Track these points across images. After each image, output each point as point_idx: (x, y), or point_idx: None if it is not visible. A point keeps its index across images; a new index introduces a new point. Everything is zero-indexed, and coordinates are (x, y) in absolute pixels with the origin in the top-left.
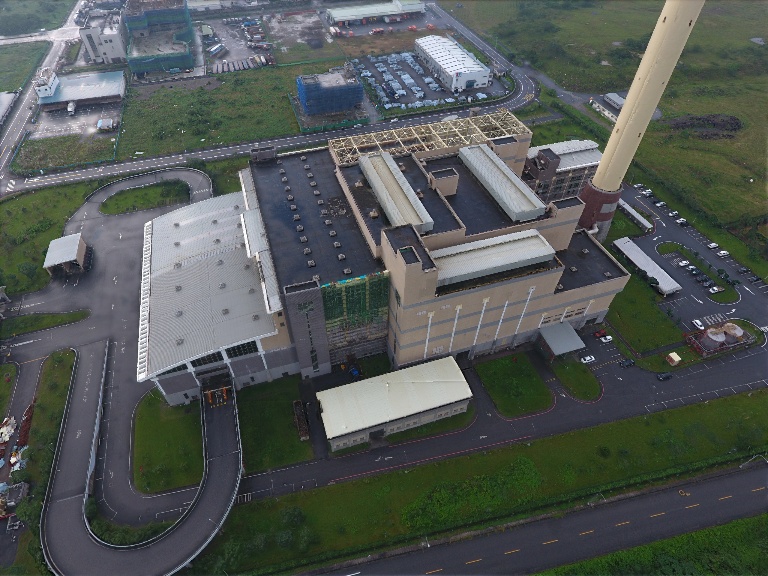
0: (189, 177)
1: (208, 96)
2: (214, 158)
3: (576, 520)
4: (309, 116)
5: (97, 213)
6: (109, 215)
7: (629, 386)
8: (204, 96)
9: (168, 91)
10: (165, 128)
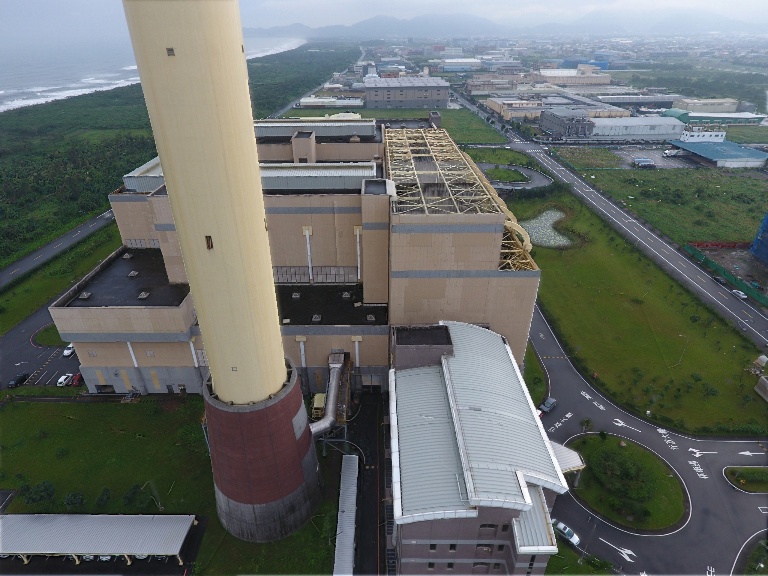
0: (534, 185)
1: (763, 199)
2: (589, 202)
3: (2, 285)
4: (750, 256)
5: (488, 168)
6: (484, 171)
7: (3, 366)
8: (762, 198)
9: (759, 183)
10: (652, 183)
